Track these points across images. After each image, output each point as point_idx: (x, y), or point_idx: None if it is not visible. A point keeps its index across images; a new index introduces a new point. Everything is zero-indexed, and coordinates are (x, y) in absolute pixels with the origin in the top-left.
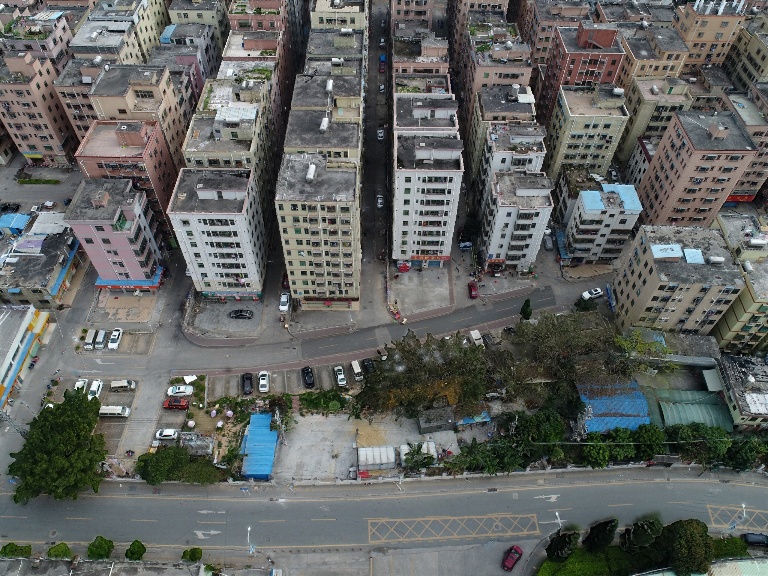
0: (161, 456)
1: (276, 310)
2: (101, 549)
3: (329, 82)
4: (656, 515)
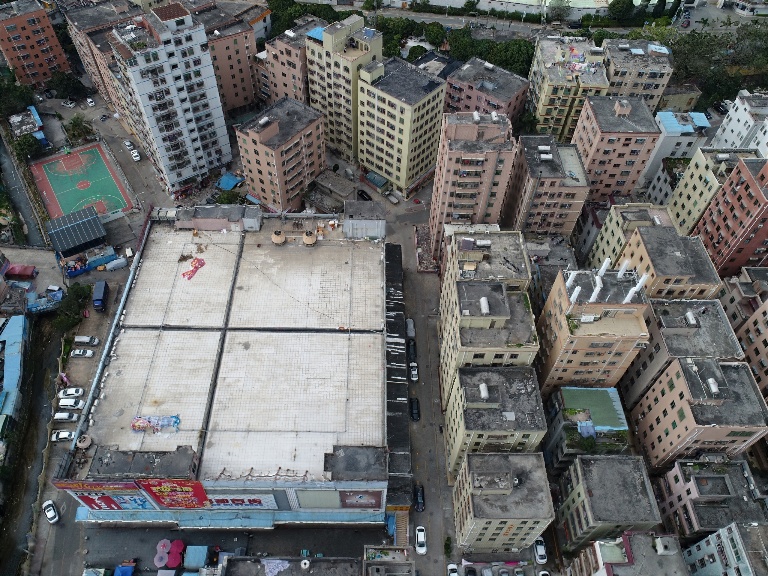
0: None
1: None
2: None
3: None
4: None
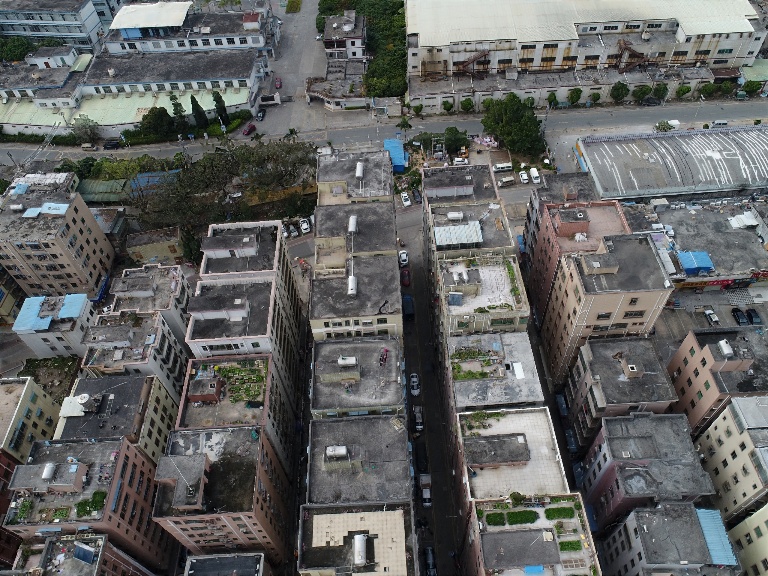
0: (451, 132)
1: (410, 253)
2: (465, 101)
3: (352, 286)
4: (160, 153)
